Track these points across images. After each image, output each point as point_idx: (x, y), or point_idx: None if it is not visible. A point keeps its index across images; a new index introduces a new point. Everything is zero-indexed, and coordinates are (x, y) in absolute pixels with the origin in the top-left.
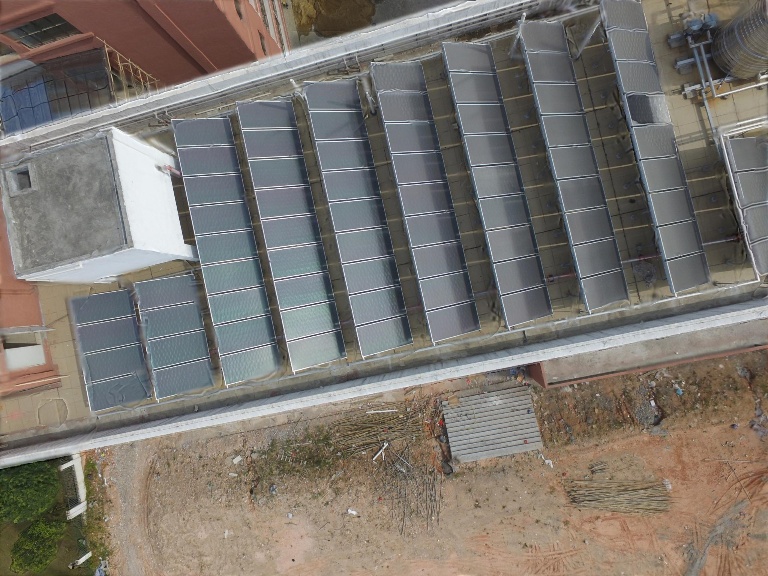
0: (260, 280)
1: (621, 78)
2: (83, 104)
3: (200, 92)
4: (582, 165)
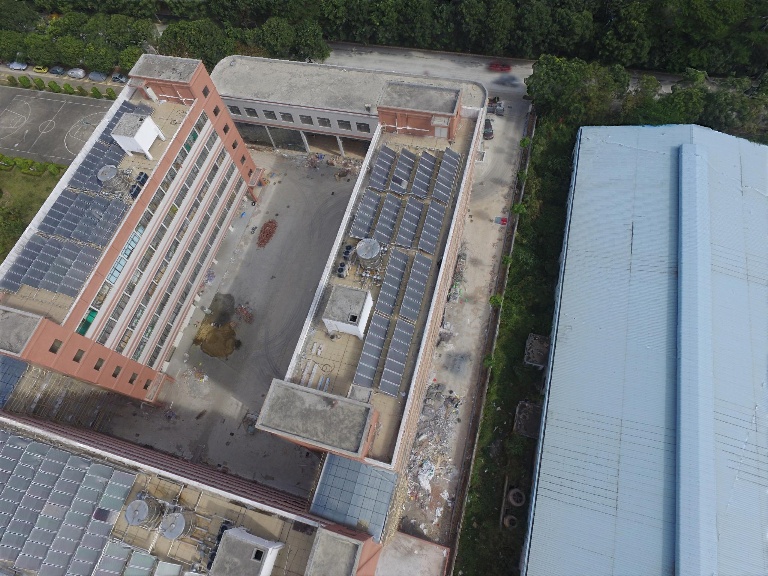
0: None
1: (102, 500)
2: (7, 379)
3: (8, 423)
4: (80, 522)
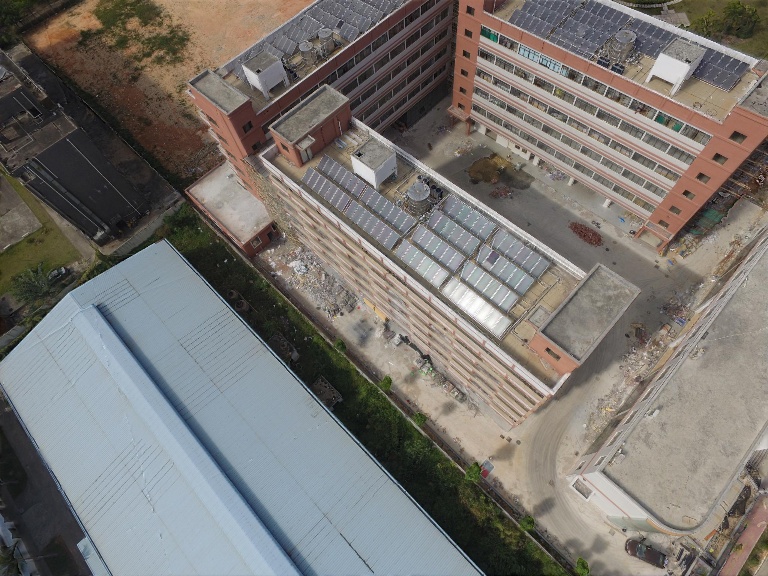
0: None
1: (347, 24)
2: None
3: None
4: None
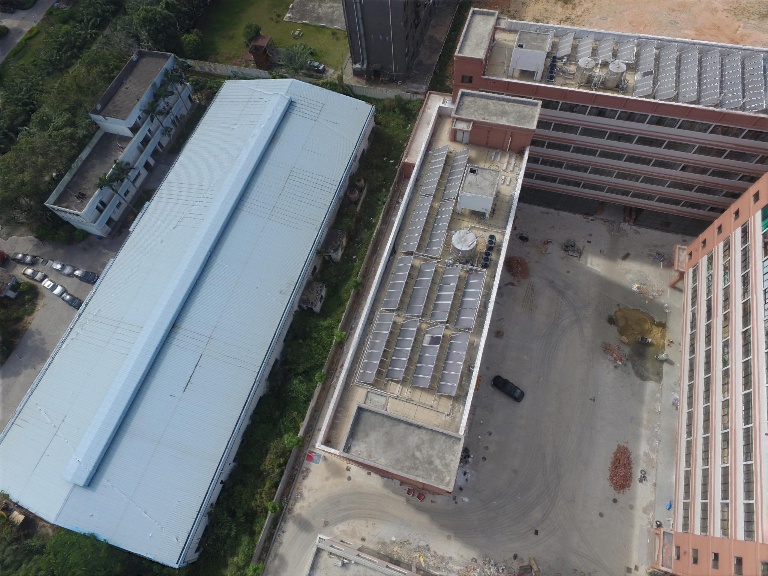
0: (765, 81)
1: None
2: None
3: None
4: None
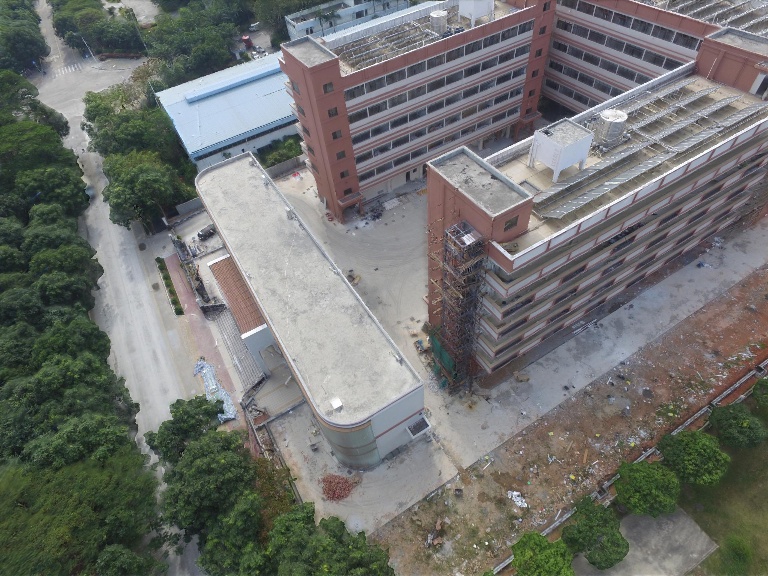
0: None
1: None
2: None
3: None
4: None
